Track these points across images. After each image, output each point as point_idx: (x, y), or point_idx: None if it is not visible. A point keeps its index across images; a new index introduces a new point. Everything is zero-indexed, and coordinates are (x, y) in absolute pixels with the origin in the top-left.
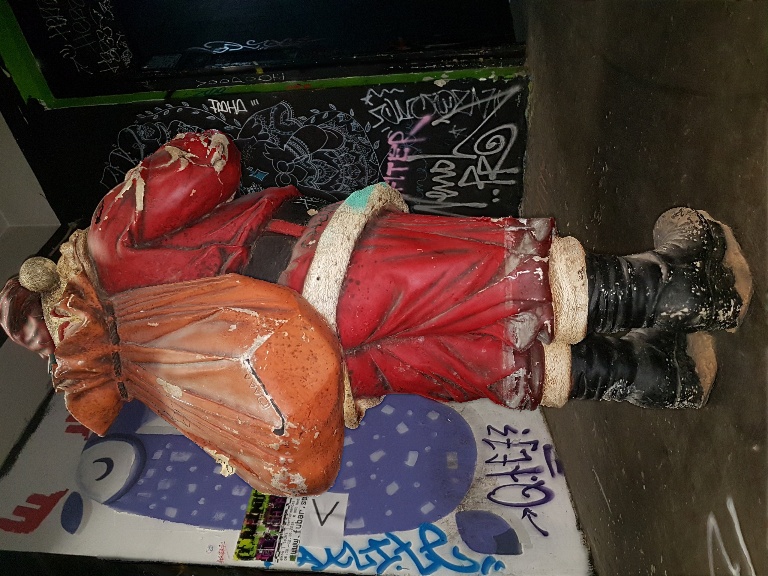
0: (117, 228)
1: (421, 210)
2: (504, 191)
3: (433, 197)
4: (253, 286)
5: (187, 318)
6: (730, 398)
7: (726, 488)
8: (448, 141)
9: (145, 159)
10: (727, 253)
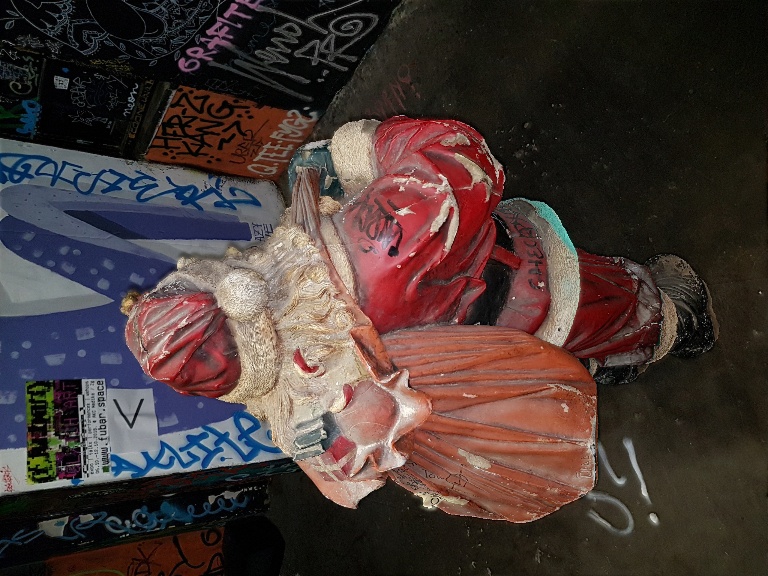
0: (416, 266)
1: (241, 66)
2: (333, 74)
3: (261, 57)
4: (555, 354)
5: (513, 392)
6: (652, 381)
7: (625, 431)
8: (310, 6)
9: (435, 167)
10: (708, 304)
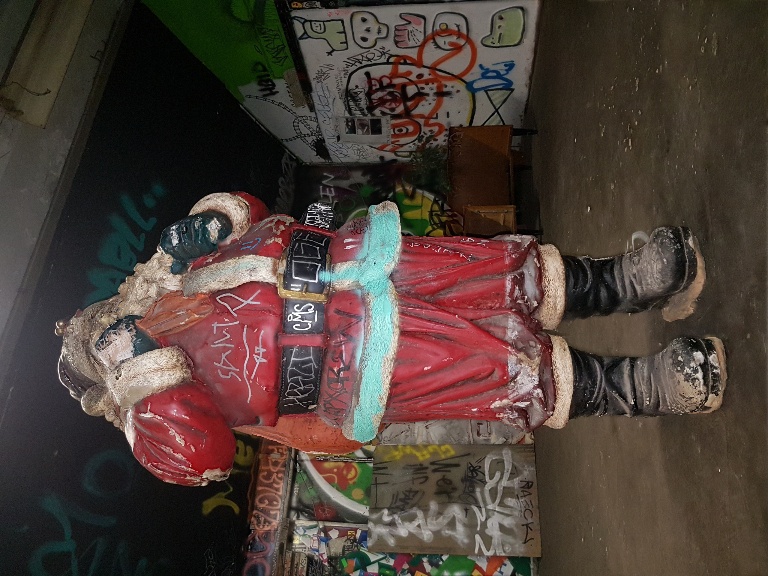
0: None
1: None
2: None
3: None
4: None
5: None
6: None
7: None
8: None
9: None
10: None
